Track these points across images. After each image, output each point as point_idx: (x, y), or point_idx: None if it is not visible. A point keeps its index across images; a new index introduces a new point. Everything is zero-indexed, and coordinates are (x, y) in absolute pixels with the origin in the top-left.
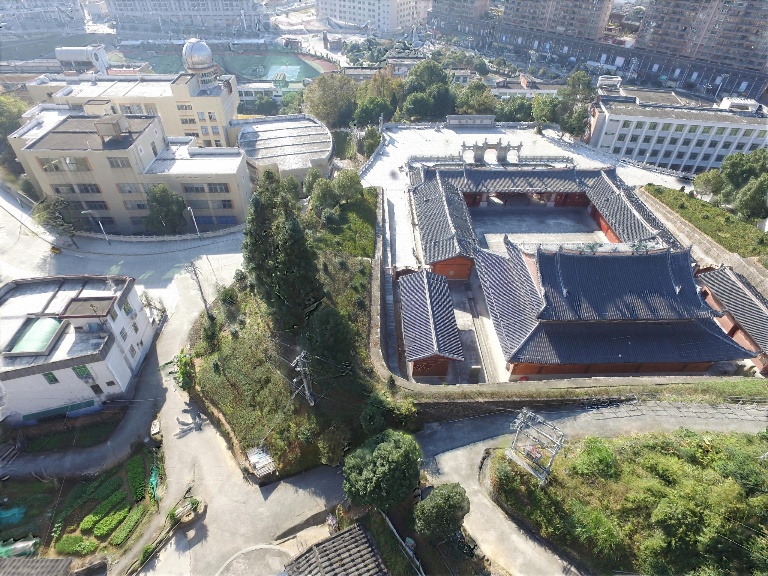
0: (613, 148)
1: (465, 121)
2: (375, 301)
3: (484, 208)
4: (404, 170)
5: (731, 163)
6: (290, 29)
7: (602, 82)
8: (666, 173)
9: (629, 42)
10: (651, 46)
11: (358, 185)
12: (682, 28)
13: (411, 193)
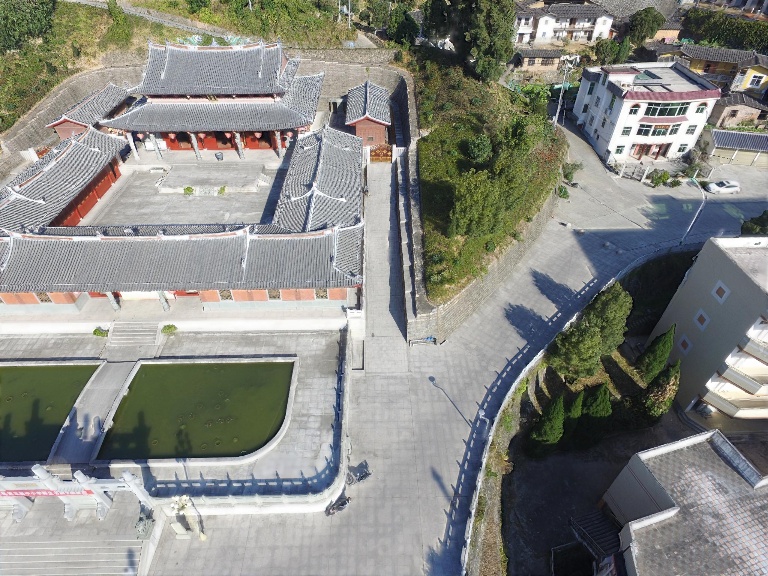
0: None
1: None
2: (412, 105)
3: None
4: (354, 475)
5: None
6: None
7: None
8: None
9: None
10: None
11: None
12: None
13: (355, 301)
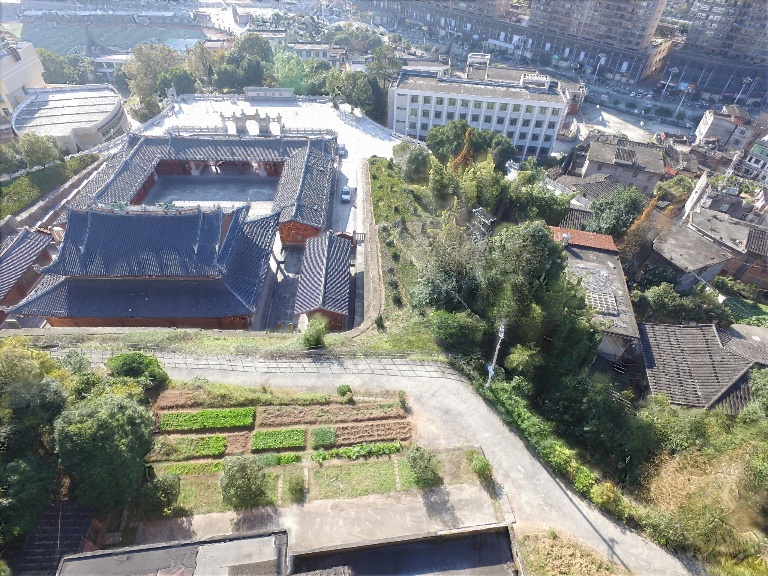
0: (408, 123)
1: (264, 94)
2: None
3: (195, 176)
4: None
5: (430, 135)
6: (208, 2)
7: (473, 60)
8: None
9: (524, 20)
10: (542, 24)
11: (42, 150)
12: (568, 6)
13: None
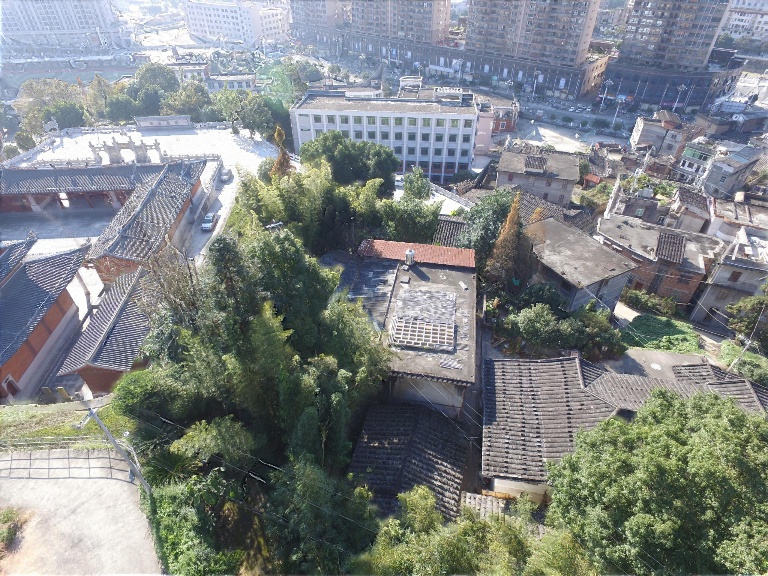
0: None
1: (157, 123)
2: None
3: (37, 212)
4: None
5: (302, 150)
6: (152, 45)
7: (406, 83)
8: None
9: (461, 44)
10: (478, 47)
11: None
12: (501, 27)
13: None
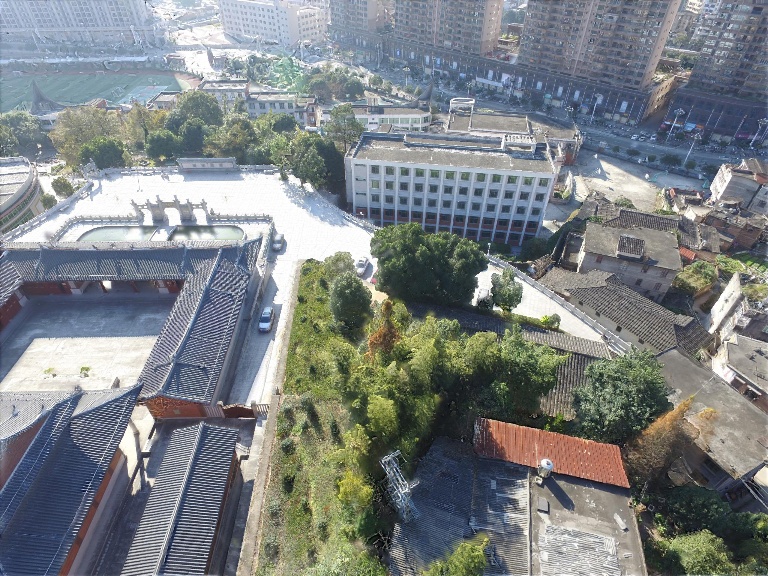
0: (370, 196)
1: (201, 165)
2: None
3: (77, 296)
4: None
5: (374, 241)
6: (186, 44)
7: (456, 105)
8: None
9: (513, 58)
10: (532, 62)
11: None
12: (559, 43)
13: None
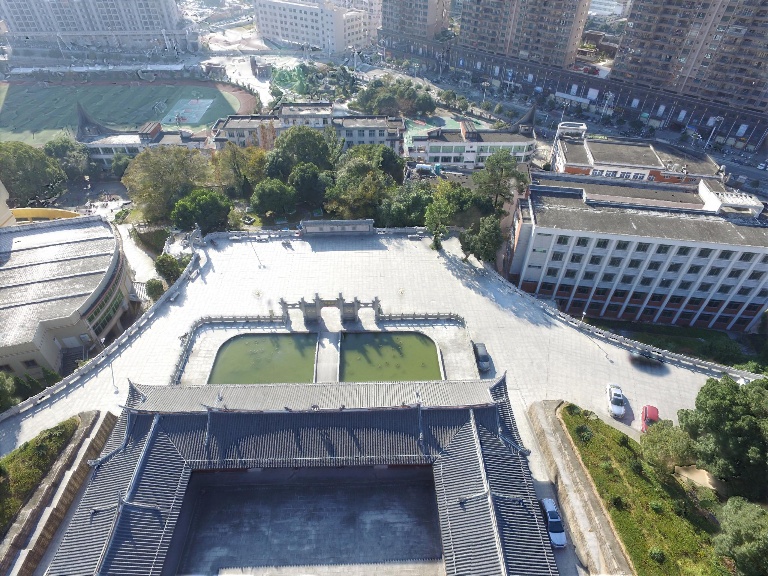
0: (547, 269)
1: (329, 228)
2: None
3: (255, 476)
4: None
5: (713, 406)
6: (221, 50)
7: (563, 130)
8: (615, 340)
9: (603, 71)
10: (629, 77)
11: None
12: (666, 57)
13: None
